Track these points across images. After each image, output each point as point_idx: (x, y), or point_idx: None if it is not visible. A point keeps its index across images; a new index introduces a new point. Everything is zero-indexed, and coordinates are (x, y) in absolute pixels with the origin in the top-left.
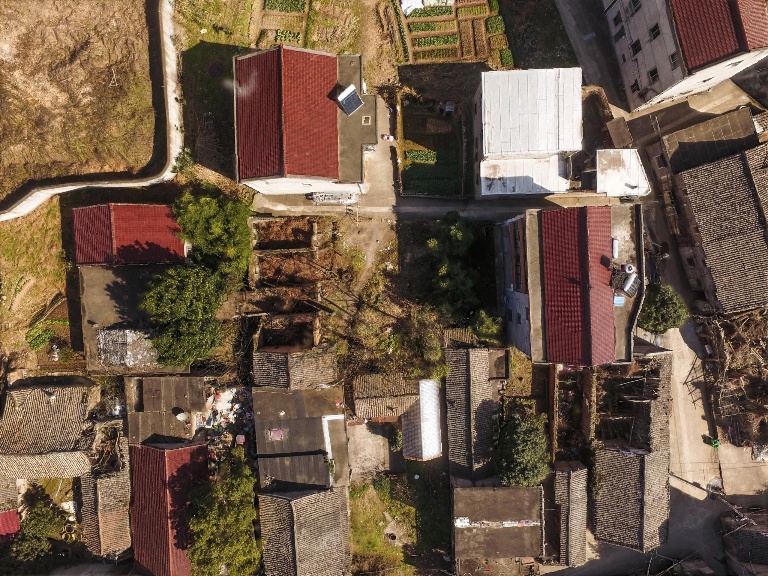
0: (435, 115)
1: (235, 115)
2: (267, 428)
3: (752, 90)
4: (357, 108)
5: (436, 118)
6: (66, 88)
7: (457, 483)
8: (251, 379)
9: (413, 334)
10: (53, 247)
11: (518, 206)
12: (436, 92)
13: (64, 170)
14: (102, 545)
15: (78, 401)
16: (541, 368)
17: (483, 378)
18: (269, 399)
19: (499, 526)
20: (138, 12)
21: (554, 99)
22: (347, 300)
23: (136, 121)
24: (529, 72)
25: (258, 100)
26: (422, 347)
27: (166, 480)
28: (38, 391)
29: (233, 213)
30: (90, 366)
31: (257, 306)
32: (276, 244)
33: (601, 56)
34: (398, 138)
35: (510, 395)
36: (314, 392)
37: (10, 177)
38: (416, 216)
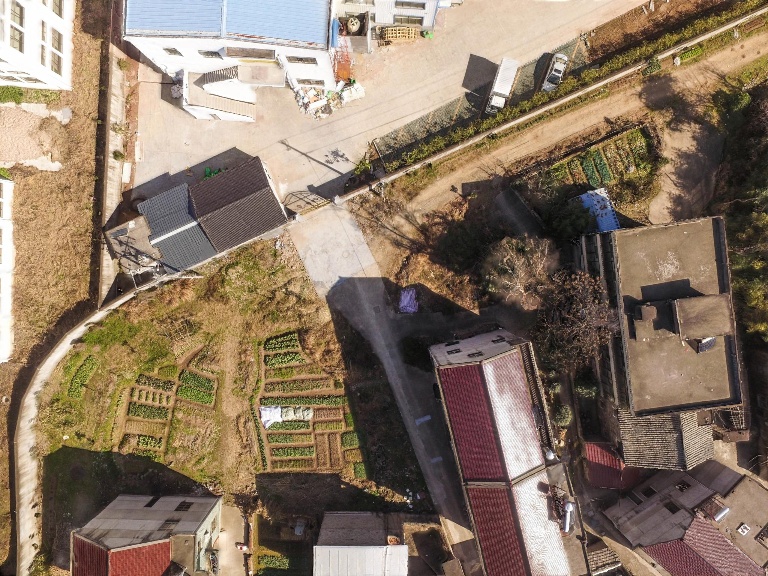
0: None
1: None
2: None
3: (586, 517)
4: None
5: None
6: None
7: None
8: None
9: None
10: None
11: None
12: (291, 500)
13: None
14: None
15: None
16: None
17: None
18: None
19: None
20: (0, 421)
21: (381, 574)
22: None
23: None
24: (358, 549)
25: None
26: None
27: None
28: None
29: None
30: None
31: None
32: None
33: (447, 479)
34: (250, 550)
35: None
36: None
37: None
38: None
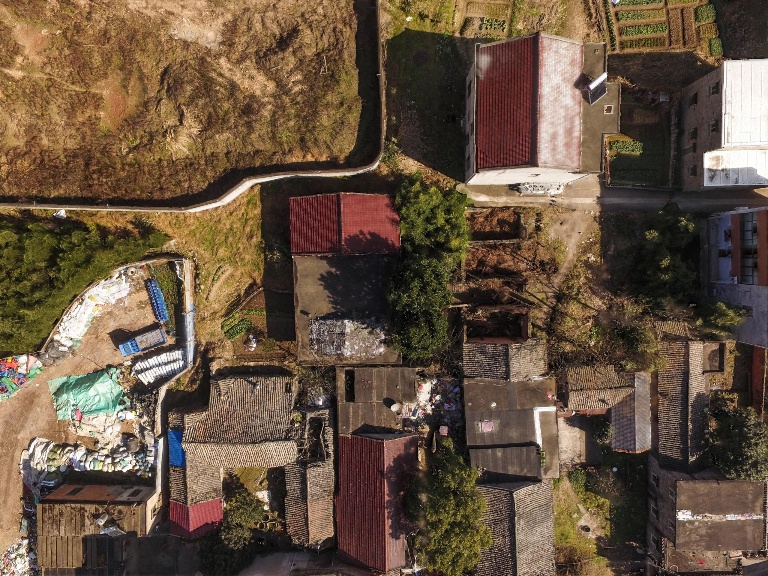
0: (642, 105)
1: (475, 104)
2: (478, 419)
3: None
4: (600, 97)
5: (643, 108)
6: (273, 76)
7: (675, 476)
8: (460, 370)
9: (620, 326)
10: (253, 237)
11: (725, 198)
12: (643, 82)
13: (268, 159)
14: (310, 534)
15: (282, 391)
16: (744, 362)
17: (698, 371)
18: (481, 390)
19: (722, 519)
20: None
21: None
22: (547, 292)
23: (344, 110)
24: None
25: (505, 88)
26: (635, 339)
27: (384, 470)
28: (241, 381)
29: (456, 203)
30: (301, 356)
31: (456, 297)
32: (481, 235)
33: None
34: None
35: (710, 388)
36: (526, 384)
37: (212, 166)
38: (620, 207)
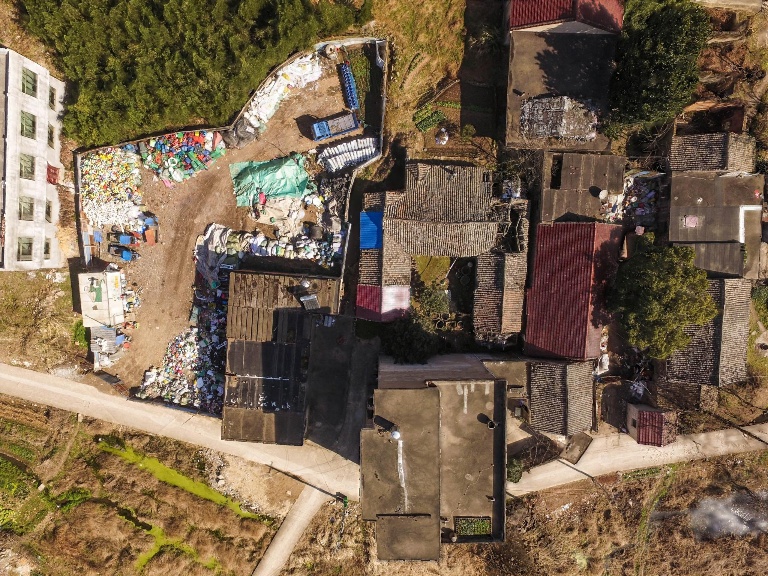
0: None
1: None
2: (683, 214)
3: None
4: None
5: None
6: None
7: None
8: (666, 165)
9: None
10: (457, 22)
11: None
12: None
13: None
14: (503, 323)
15: (480, 180)
16: None
17: None
18: (688, 184)
19: None
20: None
21: None
22: (748, 101)
23: None
24: None
25: None
26: None
27: (593, 253)
28: (437, 168)
29: None
30: (510, 138)
31: None
32: None
33: None
34: None
35: None
36: (735, 180)
37: None
38: None
